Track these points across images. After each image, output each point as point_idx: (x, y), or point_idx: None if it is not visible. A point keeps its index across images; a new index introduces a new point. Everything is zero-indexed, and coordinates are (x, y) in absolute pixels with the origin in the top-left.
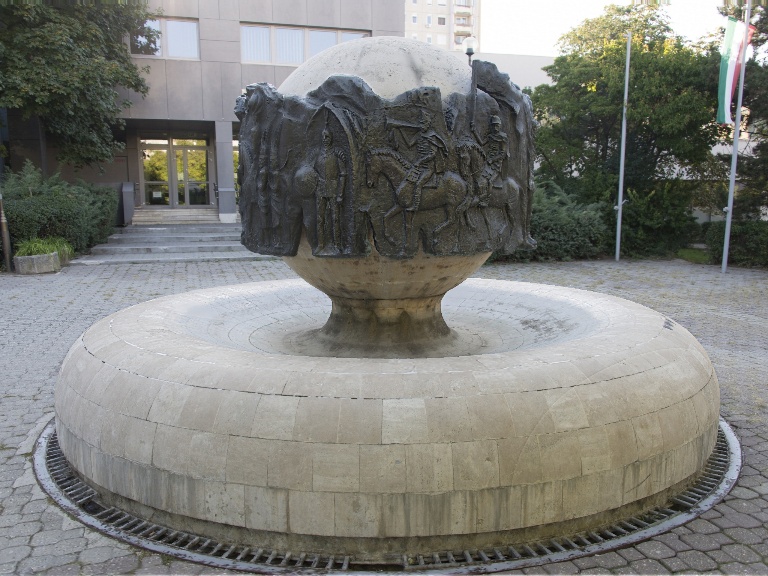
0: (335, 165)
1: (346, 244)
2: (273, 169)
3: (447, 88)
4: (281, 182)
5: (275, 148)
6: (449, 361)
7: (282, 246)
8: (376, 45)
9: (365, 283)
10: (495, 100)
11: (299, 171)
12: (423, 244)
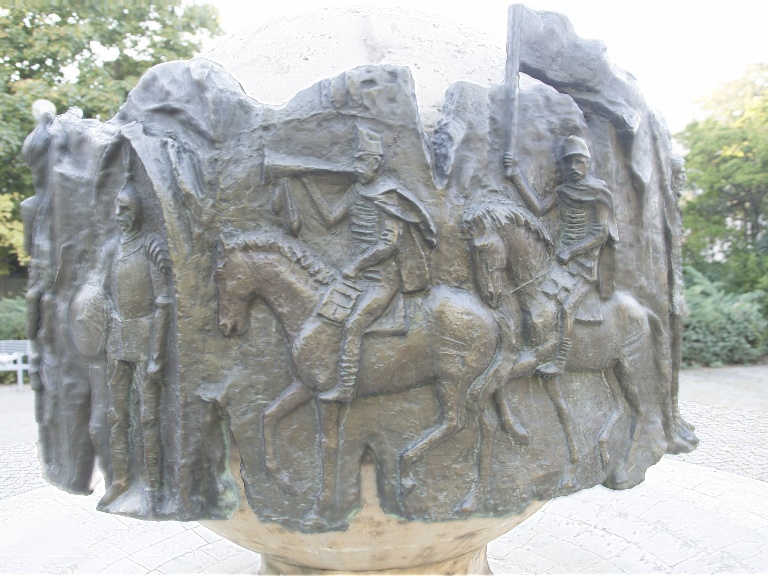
0: (144, 279)
1: (171, 485)
2: (43, 290)
3: (447, 80)
4: (52, 320)
5: (45, 242)
6: None
7: (56, 471)
8: (299, 11)
9: (276, 546)
10: (571, 99)
11: (76, 295)
12: (377, 487)
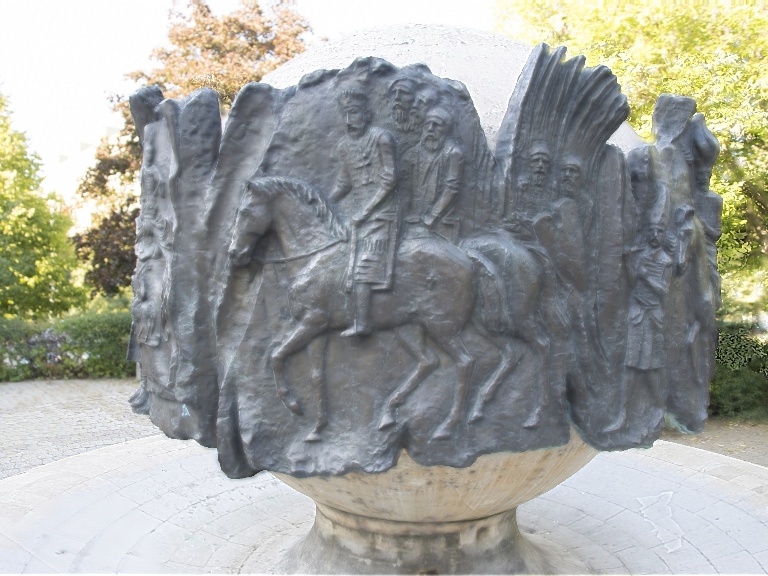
0: None
1: None
2: None
3: None
4: None
5: None
6: (681, 451)
7: None
8: None
9: None
10: None
11: None
12: None
